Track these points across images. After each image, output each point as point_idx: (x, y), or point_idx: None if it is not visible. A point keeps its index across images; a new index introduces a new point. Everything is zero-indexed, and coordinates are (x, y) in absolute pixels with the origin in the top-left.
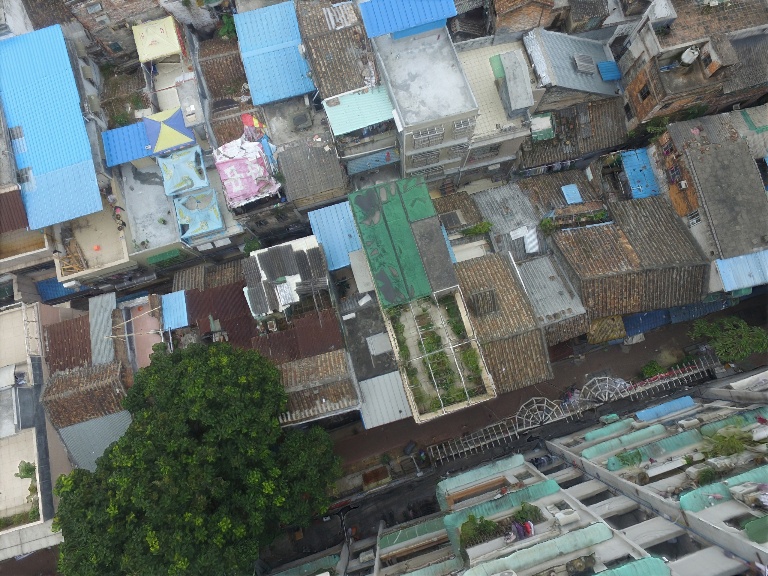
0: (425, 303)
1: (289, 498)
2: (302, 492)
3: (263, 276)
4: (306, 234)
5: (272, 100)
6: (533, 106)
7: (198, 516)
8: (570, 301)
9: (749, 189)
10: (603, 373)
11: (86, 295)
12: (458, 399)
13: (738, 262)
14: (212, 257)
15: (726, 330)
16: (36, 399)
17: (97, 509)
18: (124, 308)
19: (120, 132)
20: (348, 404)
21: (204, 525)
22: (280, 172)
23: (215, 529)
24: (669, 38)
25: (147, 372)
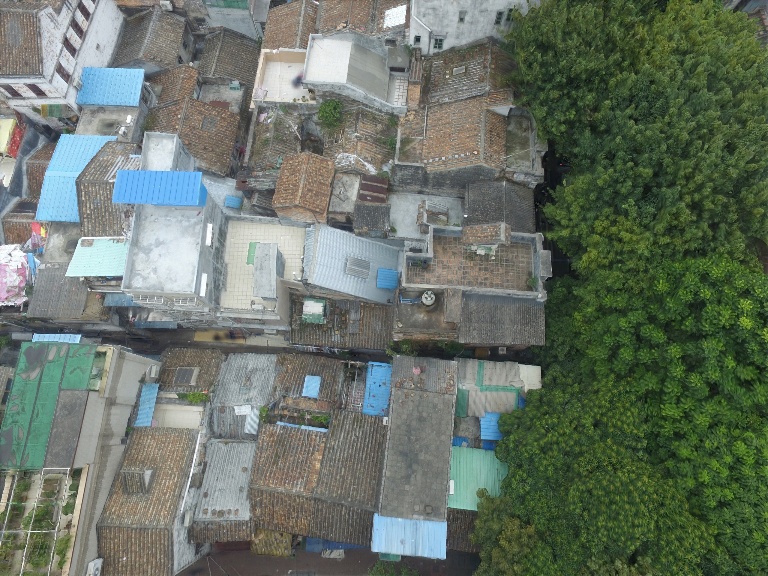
0: None
1: None
2: None
3: None
4: (93, 336)
5: (53, 220)
6: (303, 291)
7: None
8: (243, 502)
9: (435, 450)
10: (307, 575)
11: None
12: None
13: (395, 524)
14: None
15: None
16: None
17: None
18: None
19: None
20: None
21: None
22: (33, 287)
23: None
24: (426, 272)
25: None
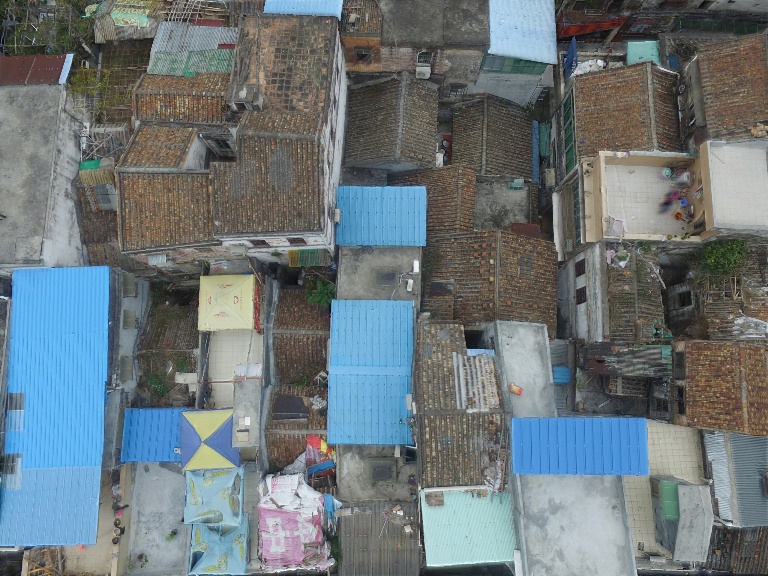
0: None
1: None
2: None
3: None
4: None
5: (353, 442)
6: None
7: None
8: None
9: None
10: None
11: None
12: None
13: None
14: None
15: None
16: None
17: None
18: None
19: (149, 415)
20: None
21: None
22: (338, 541)
23: None
24: None
25: None
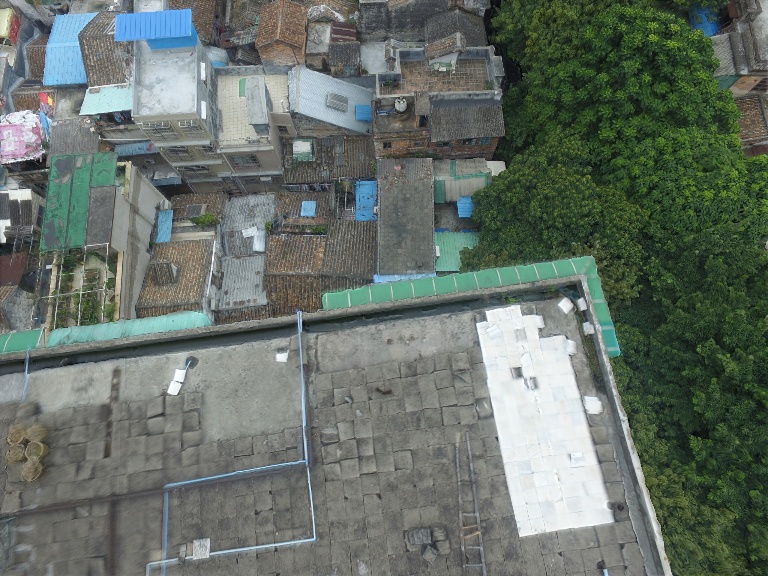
0: (100, 261)
1: None
2: None
3: None
4: None
5: (59, 84)
6: (292, 130)
7: None
8: (260, 293)
9: (420, 221)
10: None
11: None
12: None
13: None
14: None
15: None
16: None
17: None
18: None
19: None
20: None
21: None
22: (49, 142)
23: None
24: (397, 90)
25: None
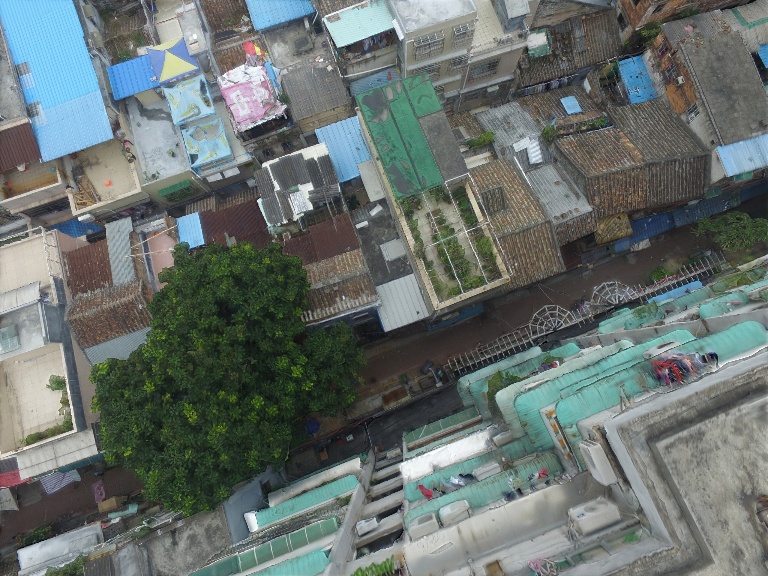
0: None
1: (317, 386)
2: (328, 382)
3: (276, 186)
4: None
5: (273, 24)
6: (528, 21)
7: (231, 393)
8: (576, 202)
9: (745, 78)
10: None
11: (99, 238)
12: (475, 285)
13: (738, 148)
14: (221, 195)
15: (730, 224)
16: (61, 318)
17: (134, 388)
18: (140, 232)
19: (125, 66)
20: (367, 300)
21: (237, 404)
22: (285, 94)
23: (248, 407)
24: None
25: (171, 271)
